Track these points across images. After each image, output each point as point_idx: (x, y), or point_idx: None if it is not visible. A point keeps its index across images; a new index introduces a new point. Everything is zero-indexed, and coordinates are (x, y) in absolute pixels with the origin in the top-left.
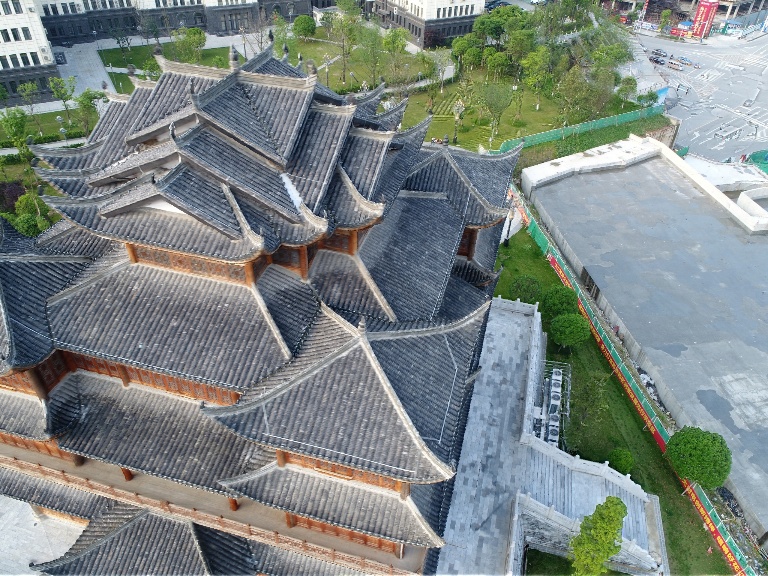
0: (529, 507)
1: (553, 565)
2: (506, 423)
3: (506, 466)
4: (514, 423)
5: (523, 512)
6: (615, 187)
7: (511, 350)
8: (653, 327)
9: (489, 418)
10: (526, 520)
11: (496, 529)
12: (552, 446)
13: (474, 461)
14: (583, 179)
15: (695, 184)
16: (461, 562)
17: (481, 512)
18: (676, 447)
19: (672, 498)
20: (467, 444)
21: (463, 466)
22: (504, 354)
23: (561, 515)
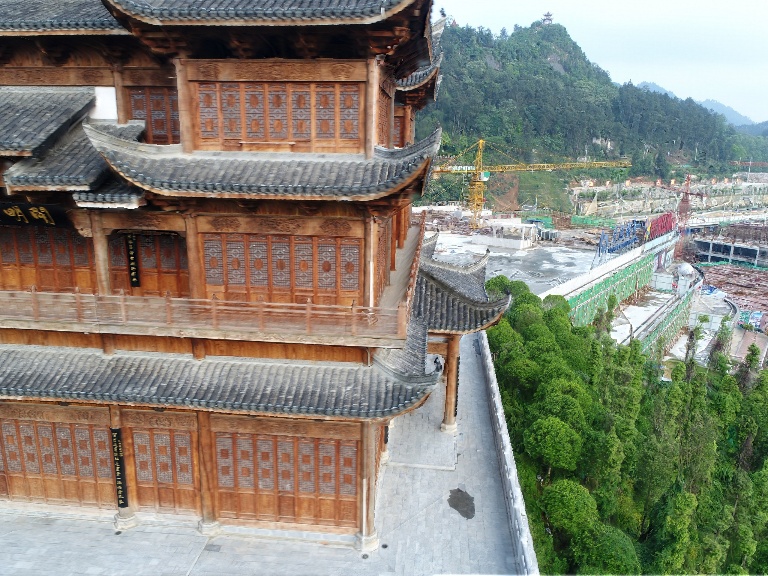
0: None
1: None
2: None
3: None
4: None
5: None
6: None
7: None
8: None
9: None
10: None
11: None
12: None
13: None
14: None
15: None
16: None
17: None
18: None
19: None
20: None
21: None
22: None
23: None
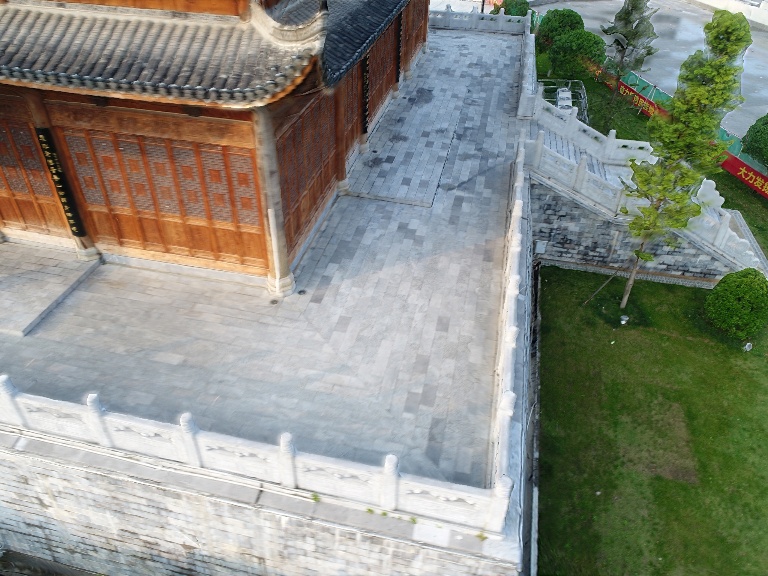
0: (541, 169)
1: (586, 281)
2: (493, 103)
3: (497, 135)
4: (506, 103)
5: (531, 178)
6: (609, 8)
7: (495, 55)
8: None
9: (466, 99)
10: (536, 200)
11: (485, 189)
12: (571, 114)
13: (443, 128)
14: (570, 4)
15: (703, 6)
16: (422, 220)
17: (457, 173)
18: (765, 125)
19: (759, 216)
20: (431, 115)
21: (424, 131)
22: (485, 57)
23: (598, 178)
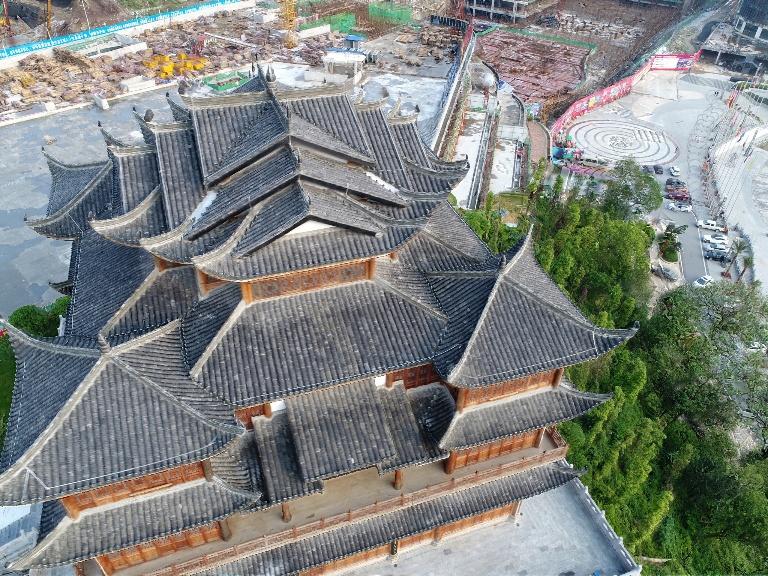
0: None
1: None
2: None
3: None
4: None
5: None
6: None
7: None
8: (7, 304)
9: None
10: None
11: None
12: None
13: None
14: None
15: None
16: None
17: None
18: None
19: None
20: None
21: None
22: None
23: None
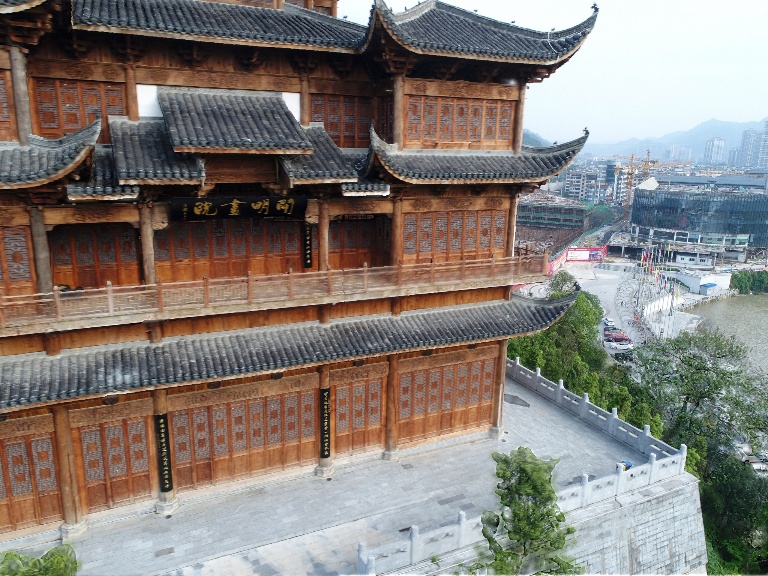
0: None
1: None
2: None
3: None
4: None
5: None
6: None
7: None
8: None
9: None
10: None
11: None
12: None
13: None
14: None
15: None
16: None
17: None
18: None
19: None
20: None
21: None
22: None
23: None
